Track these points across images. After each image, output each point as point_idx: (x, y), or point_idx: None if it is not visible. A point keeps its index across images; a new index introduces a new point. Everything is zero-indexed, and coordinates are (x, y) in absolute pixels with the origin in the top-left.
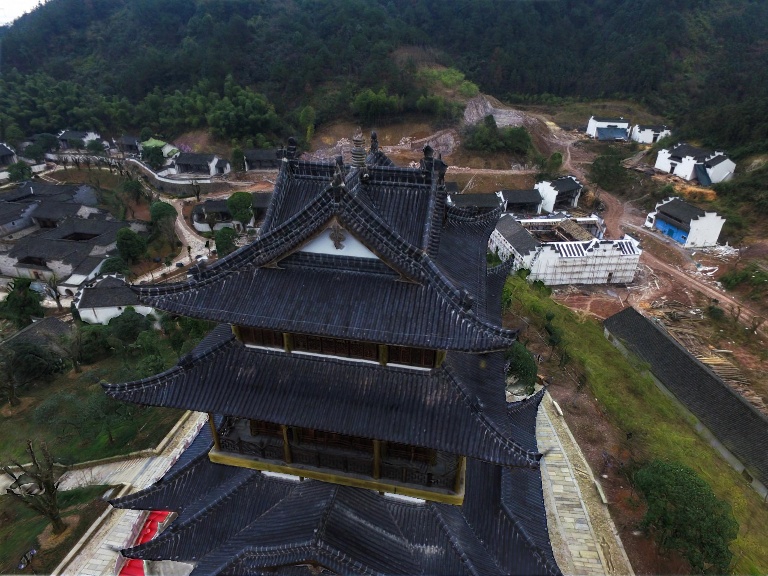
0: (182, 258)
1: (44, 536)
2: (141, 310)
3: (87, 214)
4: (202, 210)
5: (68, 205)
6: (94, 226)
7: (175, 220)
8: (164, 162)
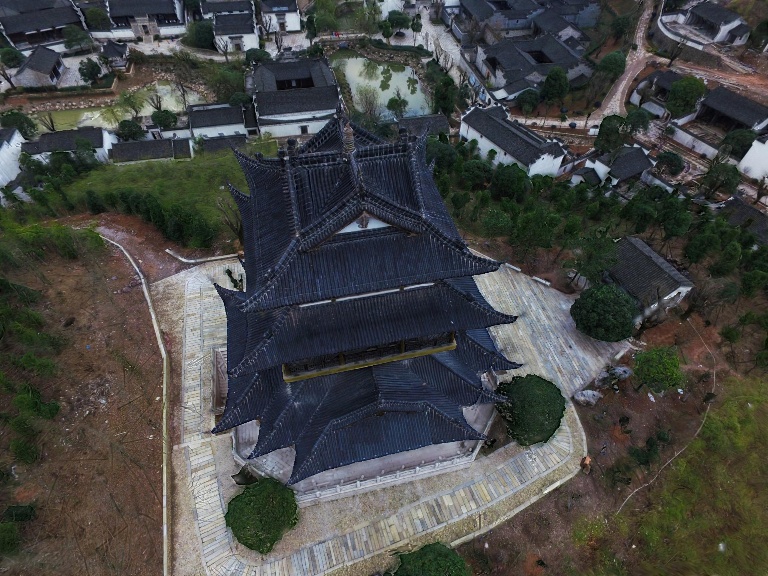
0: (585, 120)
1: None
2: (492, 147)
3: (568, 36)
4: (654, 79)
5: (561, 21)
6: (556, 51)
7: (616, 78)
8: (682, 4)
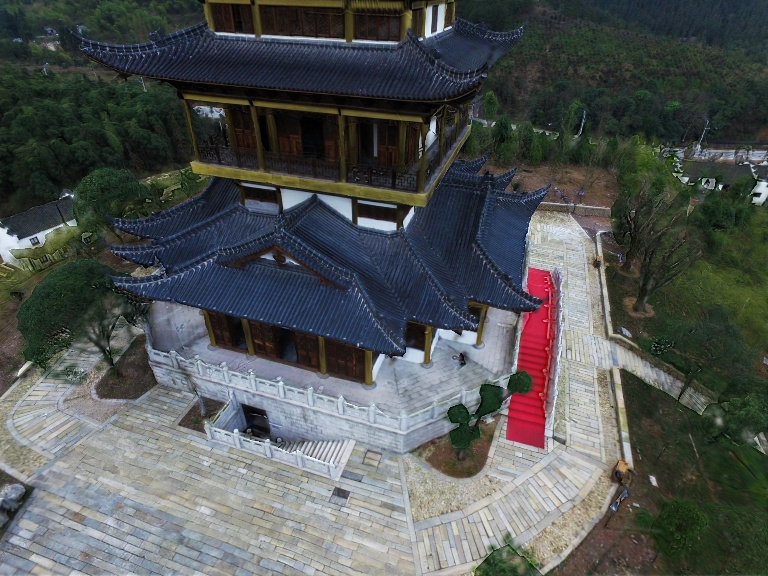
0: None
1: (647, 306)
2: None
3: None
4: None
5: None
6: None
7: None
8: None
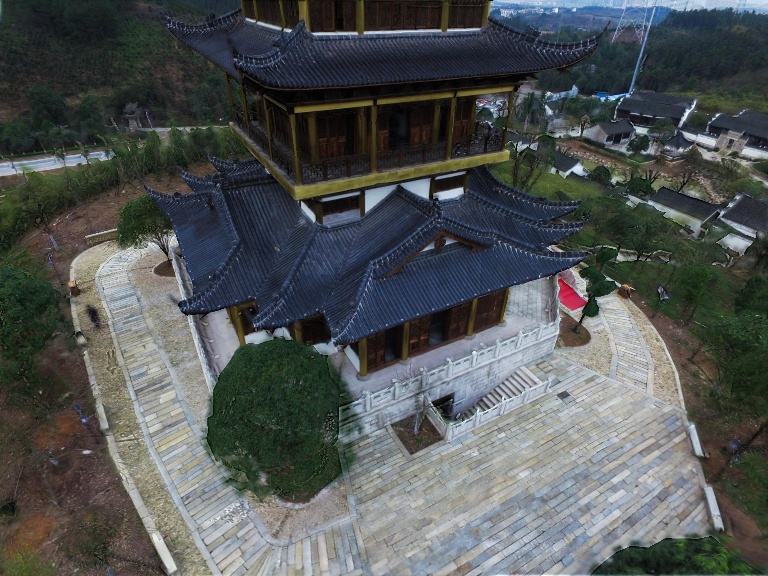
0: None
1: None
2: None
3: None
4: None
5: None
6: None
7: None
8: None
